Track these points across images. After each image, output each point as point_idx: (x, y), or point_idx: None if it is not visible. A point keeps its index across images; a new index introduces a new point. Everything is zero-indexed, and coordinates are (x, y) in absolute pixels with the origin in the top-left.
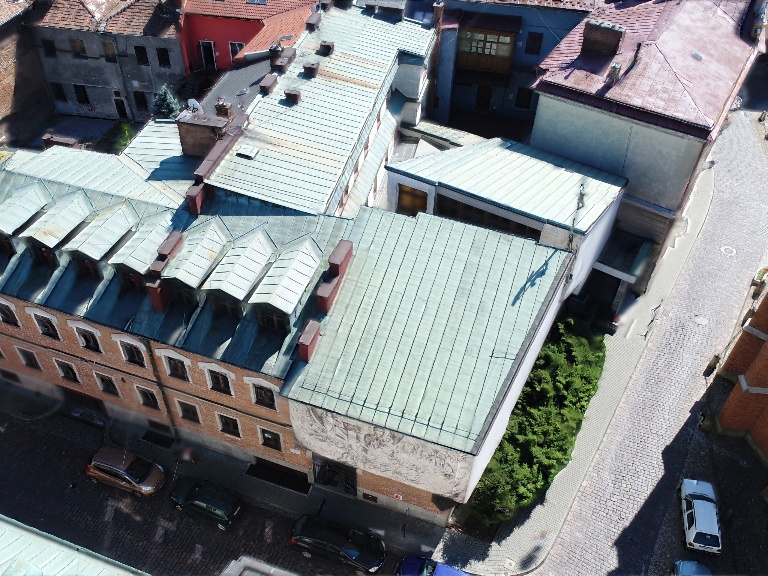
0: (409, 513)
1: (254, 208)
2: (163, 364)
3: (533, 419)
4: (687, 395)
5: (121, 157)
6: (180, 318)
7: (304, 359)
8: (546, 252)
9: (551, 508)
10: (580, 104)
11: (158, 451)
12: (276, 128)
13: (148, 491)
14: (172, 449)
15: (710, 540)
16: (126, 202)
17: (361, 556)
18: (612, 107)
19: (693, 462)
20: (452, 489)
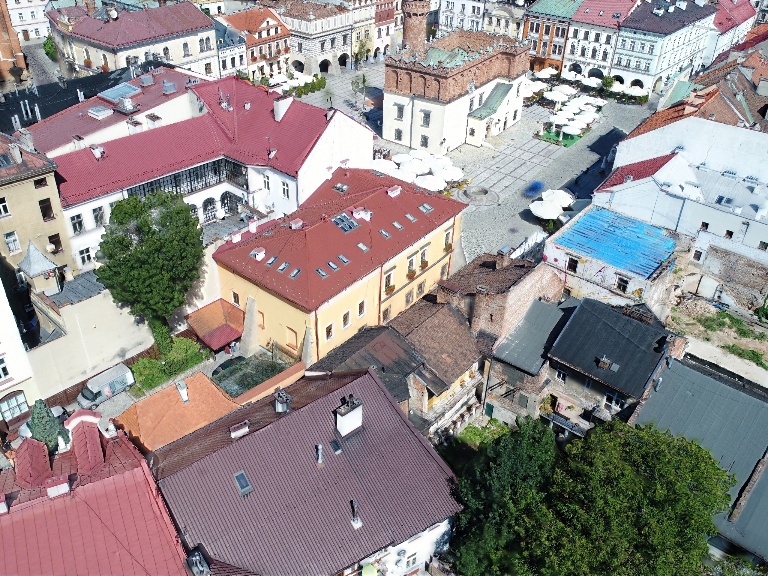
0: None
1: None
2: None
3: None
4: None
5: None
6: None
7: None
8: None
9: None
10: None
11: None
12: None
13: None
14: None
15: None
16: None
17: None
18: None
19: None
20: None
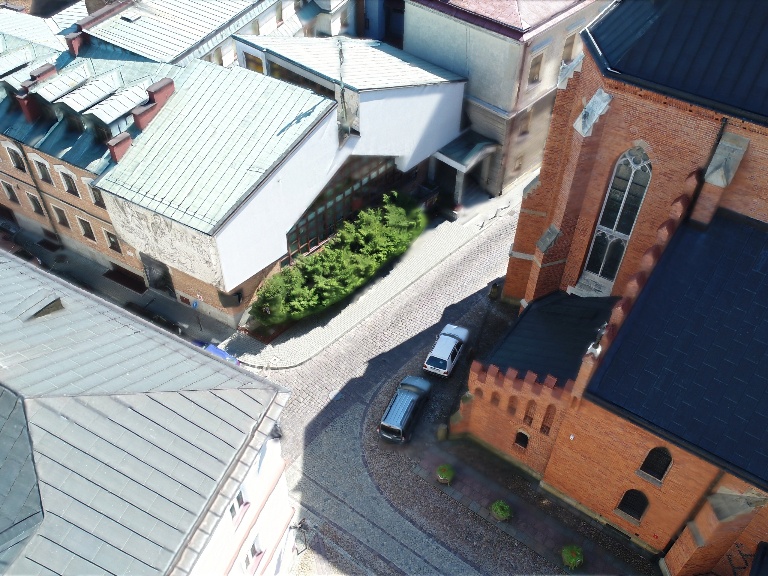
0: (212, 315)
1: (117, 54)
2: (35, 169)
3: (326, 256)
4: (493, 272)
5: (48, 20)
6: (45, 130)
7: (115, 160)
8: (317, 99)
9: (329, 330)
10: (431, 9)
11: (45, 253)
12: (165, 4)
13: None
14: (56, 253)
15: (441, 364)
16: (30, 45)
17: None
18: (453, 11)
19: (469, 318)
20: (215, 277)
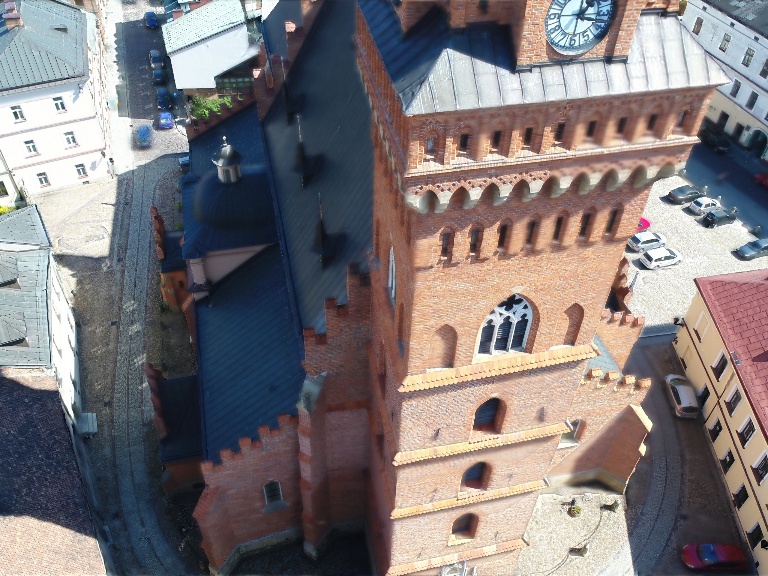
0: None
1: None
2: None
3: None
4: None
5: None
6: None
7: None
8: None
9: None
10: None
11: None
12: None
13: (153, 66)
14: None
15: None
16: None
17: (161, 102)
18: None
19: None
20: None
